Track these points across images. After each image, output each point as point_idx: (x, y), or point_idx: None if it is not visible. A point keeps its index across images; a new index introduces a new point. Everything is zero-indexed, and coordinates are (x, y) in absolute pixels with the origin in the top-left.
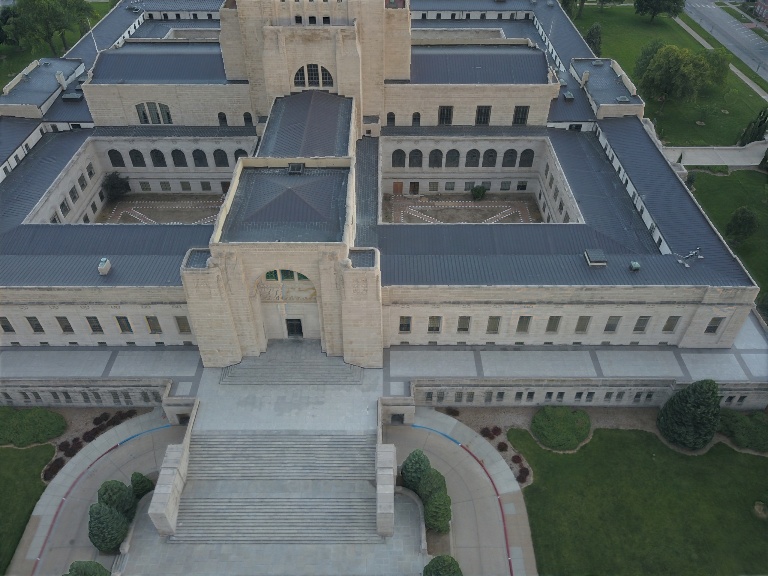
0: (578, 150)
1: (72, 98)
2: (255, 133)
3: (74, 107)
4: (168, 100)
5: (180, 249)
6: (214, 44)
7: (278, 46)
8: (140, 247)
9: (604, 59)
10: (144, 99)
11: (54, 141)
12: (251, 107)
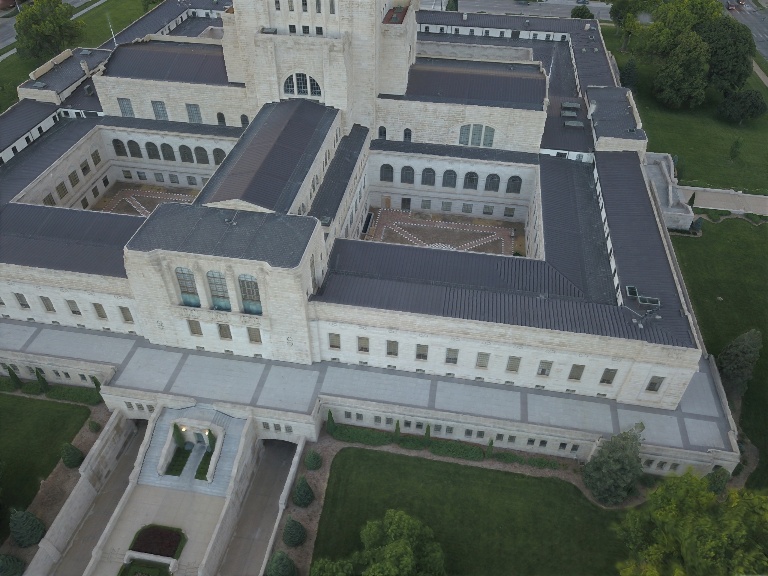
0: None
1: None
2: None
3: None
4: None
5: (435, 38)
6: None
7: None
8: None
9: (24, 88)
10: None
11: None
12: None
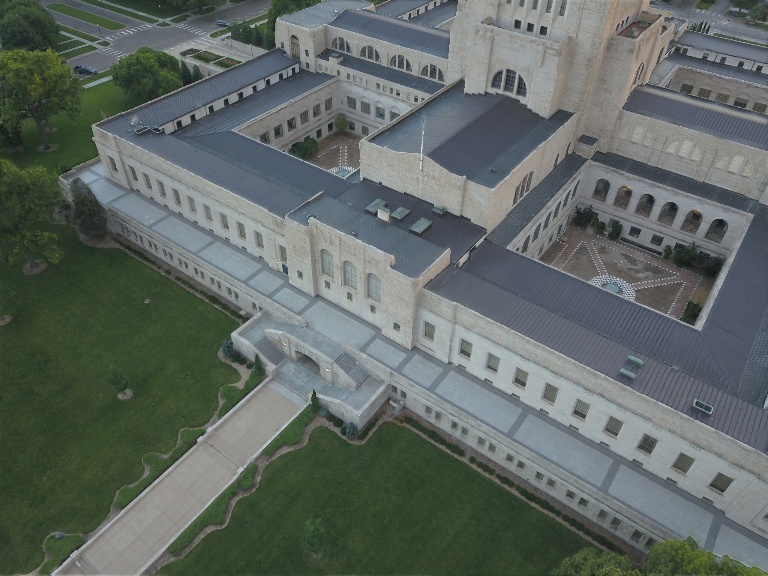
0: (698, 65)
1: (428, 226)
2: (579, 159)
3: (439, 234)
4: (536, 164)
5: None
6: (431, 104)
7: (638, 55)
8: (767, 271)
9: None
10: (523, 175)
11: (481, 277)
12: (573, 135)
